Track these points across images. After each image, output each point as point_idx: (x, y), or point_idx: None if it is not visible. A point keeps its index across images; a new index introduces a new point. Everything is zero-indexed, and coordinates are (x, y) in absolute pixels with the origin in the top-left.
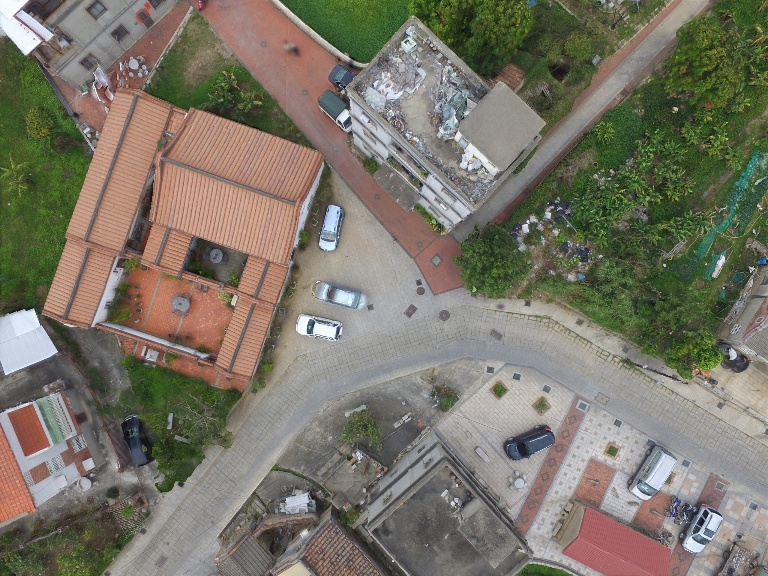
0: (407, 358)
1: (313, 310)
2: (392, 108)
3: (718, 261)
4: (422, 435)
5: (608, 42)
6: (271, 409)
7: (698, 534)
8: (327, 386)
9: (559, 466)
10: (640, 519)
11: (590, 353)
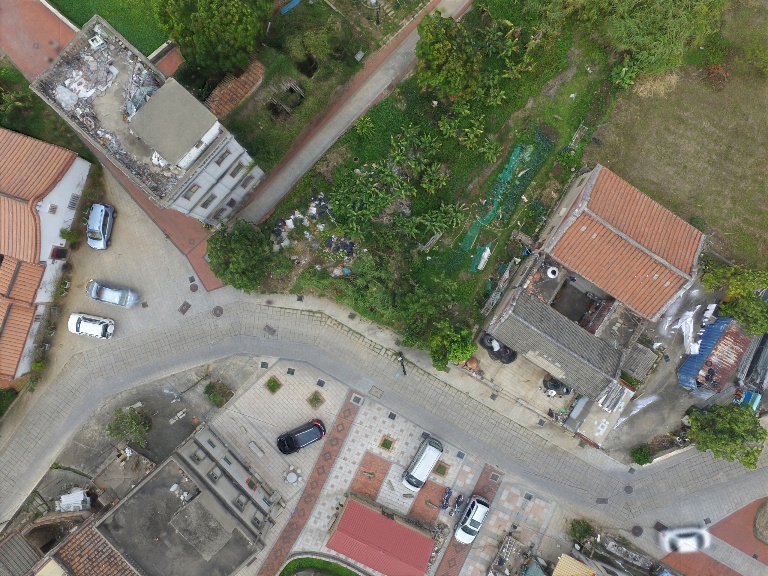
0: (182, 355)
1: (88, 308)
2: (80, 106)
3: (484, 253)
4: (197, 431)
5: (373, 37)
6: (49, 408)
7: (465, 525)
8: (104, 384)
9: (334, 460)
10: (416, 511)
11: (363, 347)
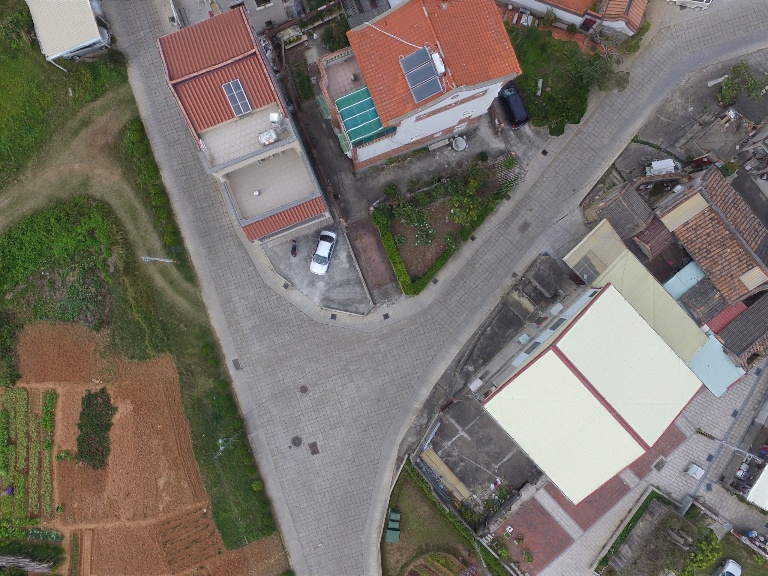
0: None
1: None
2: None
3: None
4: None
5: None
6: (634, 80)
7: None
8: (689, 58)
9: None
10: None
11: None
